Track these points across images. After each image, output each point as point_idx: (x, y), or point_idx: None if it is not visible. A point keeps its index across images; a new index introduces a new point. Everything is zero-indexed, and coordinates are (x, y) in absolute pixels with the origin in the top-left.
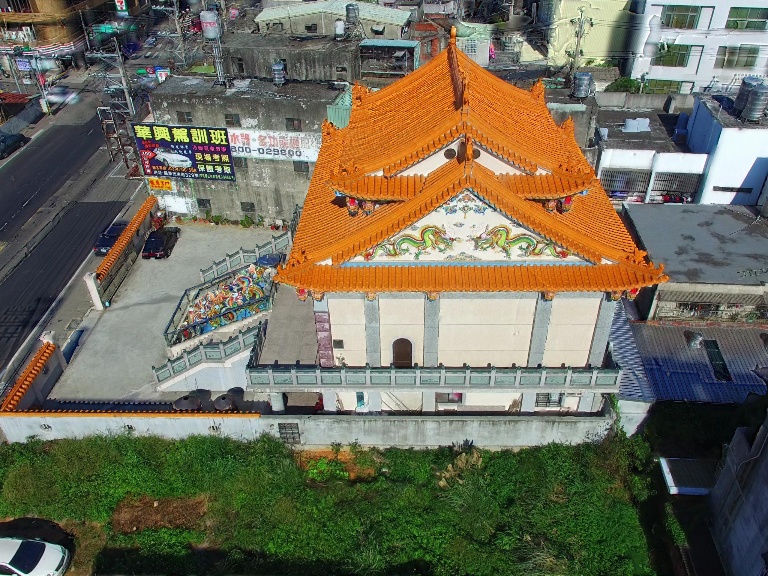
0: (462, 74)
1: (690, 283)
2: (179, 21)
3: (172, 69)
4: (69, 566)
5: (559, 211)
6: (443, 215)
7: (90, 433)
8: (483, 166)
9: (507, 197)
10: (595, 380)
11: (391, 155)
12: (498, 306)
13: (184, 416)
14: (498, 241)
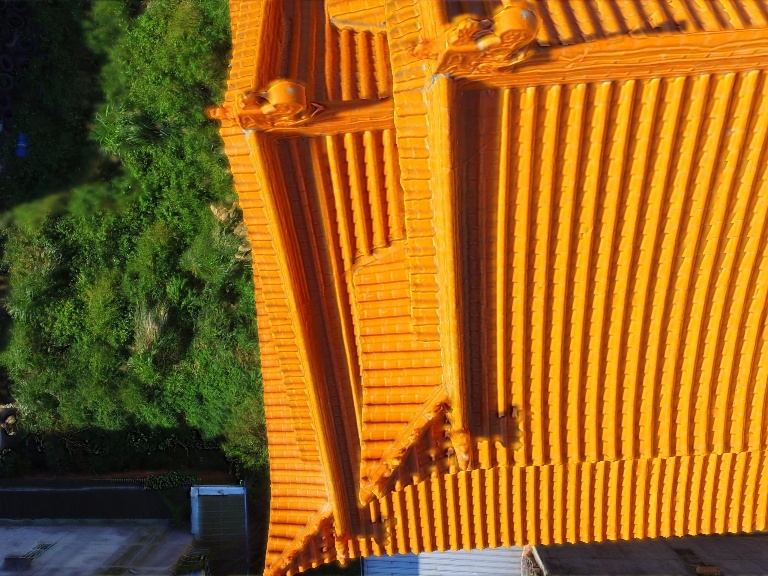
0: None
1: None
2: None
3: None
4: None
5: None
6: None
7: None
8: None
9: None
10: None
11: None
12: None
13: None
14: None
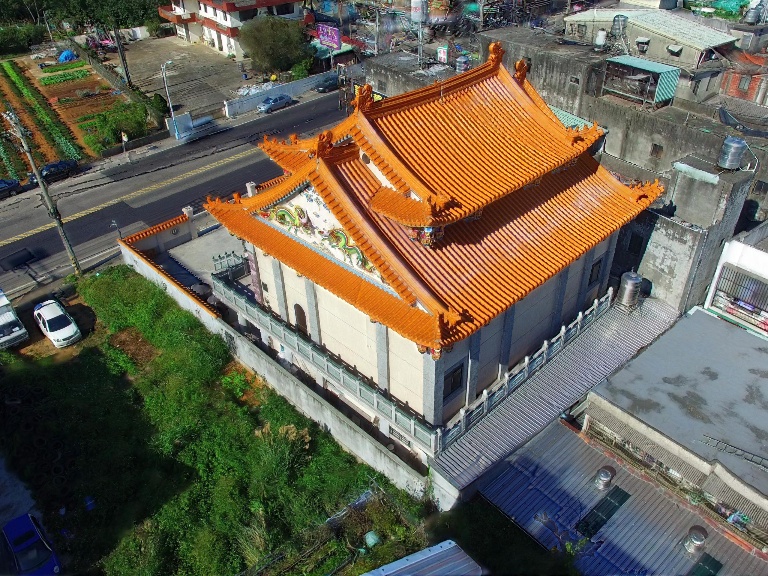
0: (439, 87)
1: (623, 410)
2: (484, 7)
3: (449, 48)
4: (75, 344)
5: (435, 246)
6: (306, 201)
7: (151, 279)
8: (373, 173)
9: (344, 202)
10: (414, 431)
11: (316, 138)
12: (353, 310)
13: (185, 293)
14: (339, 243)
